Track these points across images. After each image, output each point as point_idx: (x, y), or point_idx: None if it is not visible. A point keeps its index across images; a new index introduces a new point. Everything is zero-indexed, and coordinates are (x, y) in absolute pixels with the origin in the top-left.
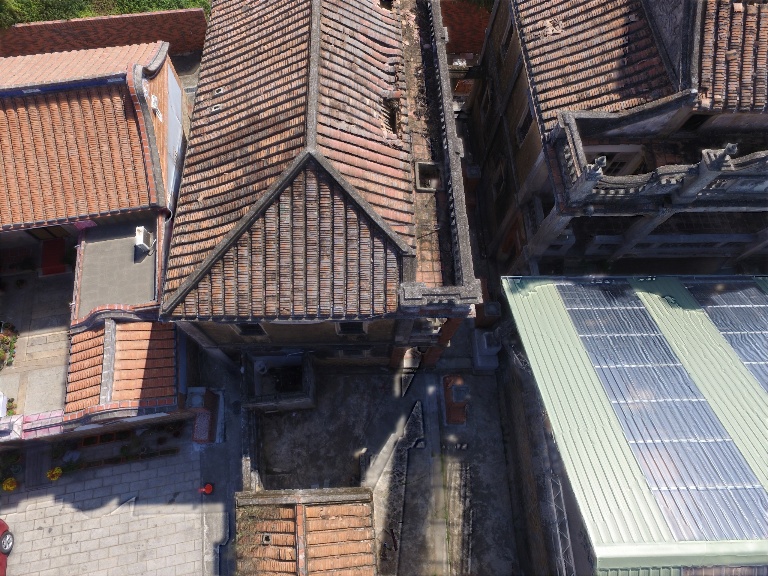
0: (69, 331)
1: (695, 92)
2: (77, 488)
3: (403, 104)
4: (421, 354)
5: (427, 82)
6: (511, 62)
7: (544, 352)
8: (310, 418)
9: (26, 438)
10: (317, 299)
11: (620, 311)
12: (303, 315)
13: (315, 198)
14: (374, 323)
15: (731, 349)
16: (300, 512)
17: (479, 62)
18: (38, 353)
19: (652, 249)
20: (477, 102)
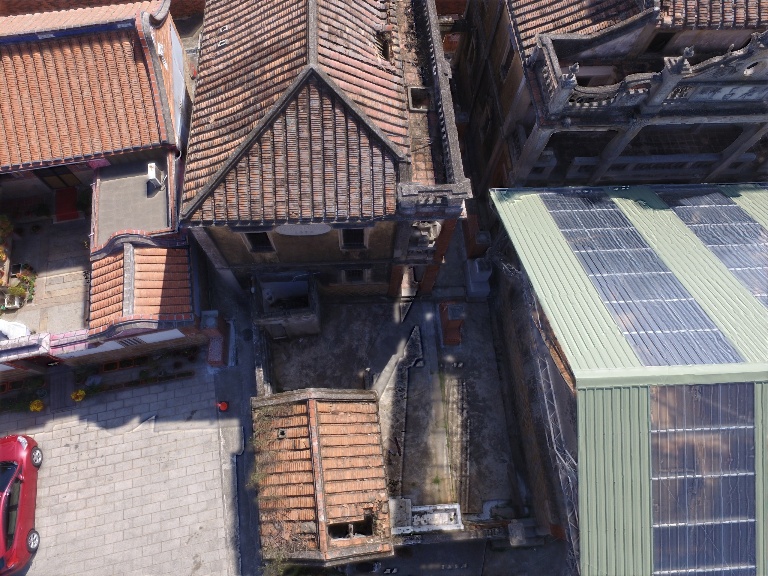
0: (85, 271)
1: (657, 9)
2: (100, 409)
3: (395, 36)
4: (418, 284)
5: (416, 19)
6: (493, 6)
7: (529, 242)
8: (316, 343)
9: (53, 354)
10: (323, 204)
11: (597, 212)
12: (310, 219)
13: (318, 111)
14: (374, 233)
15: (695, 236)
16: (312, 406)
17: (464, 16)
18: (56, 291)
19: (627, 171)
20: (463, 56)
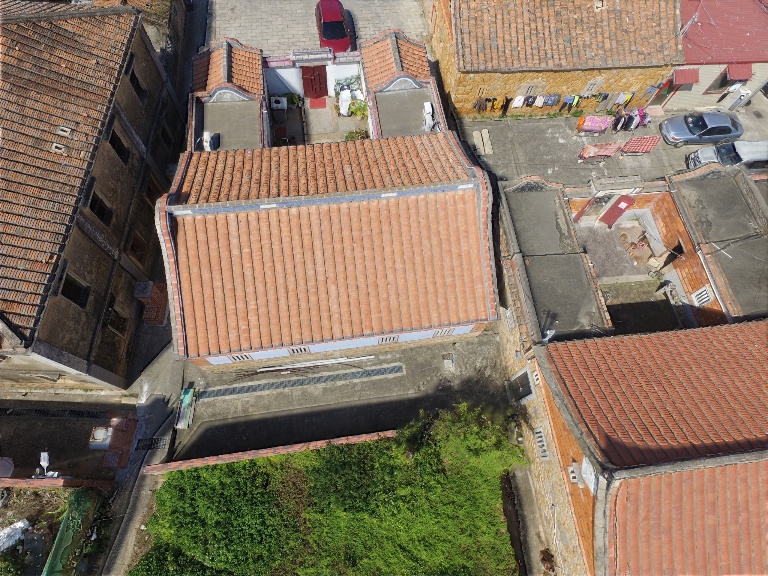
0: None
1: None
2: None
3: None
4: None
5: None
6: None
7: None
8: None
9: None
10: None
11: None
12: None
13: None
14: None
15: None
16: (119, 1)
17: None
18: None
19: None
20: None
